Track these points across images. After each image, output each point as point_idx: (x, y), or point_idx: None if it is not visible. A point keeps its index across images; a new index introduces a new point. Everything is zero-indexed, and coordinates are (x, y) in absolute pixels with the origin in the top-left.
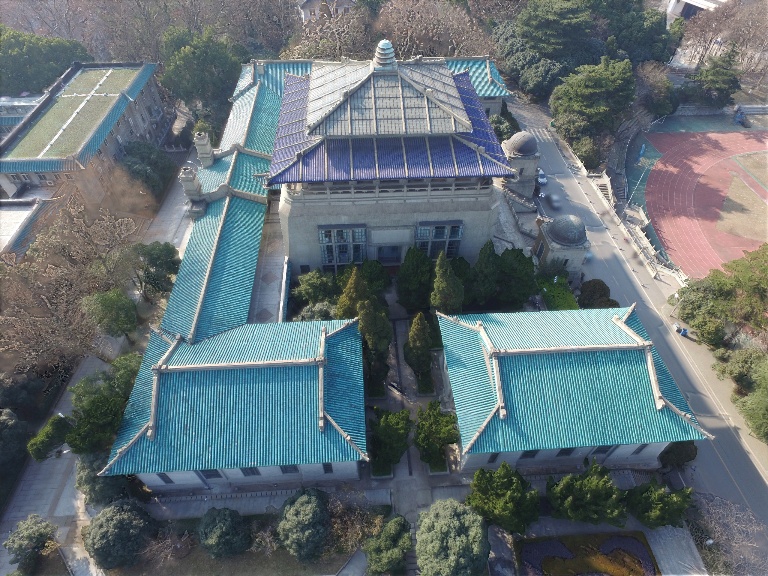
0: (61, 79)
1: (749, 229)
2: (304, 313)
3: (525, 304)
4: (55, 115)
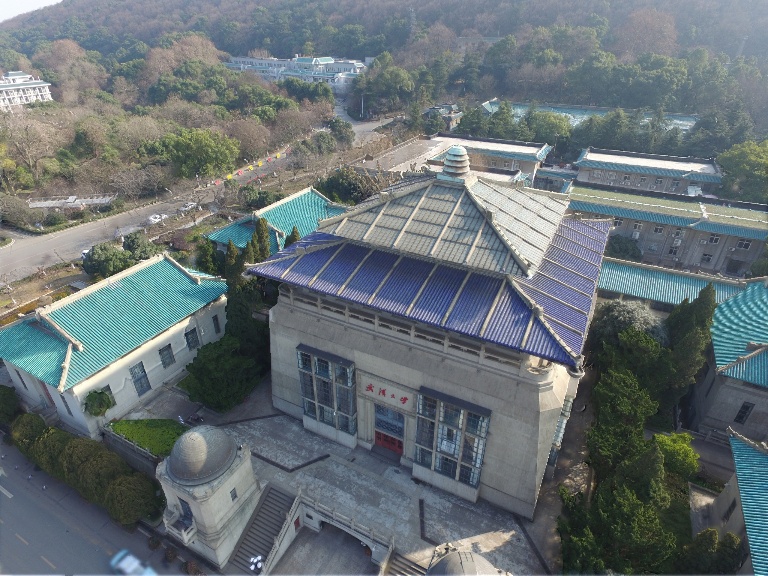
0: (736, 201)
1: None
2: None
3: (207, 414)
4: (656, 201)
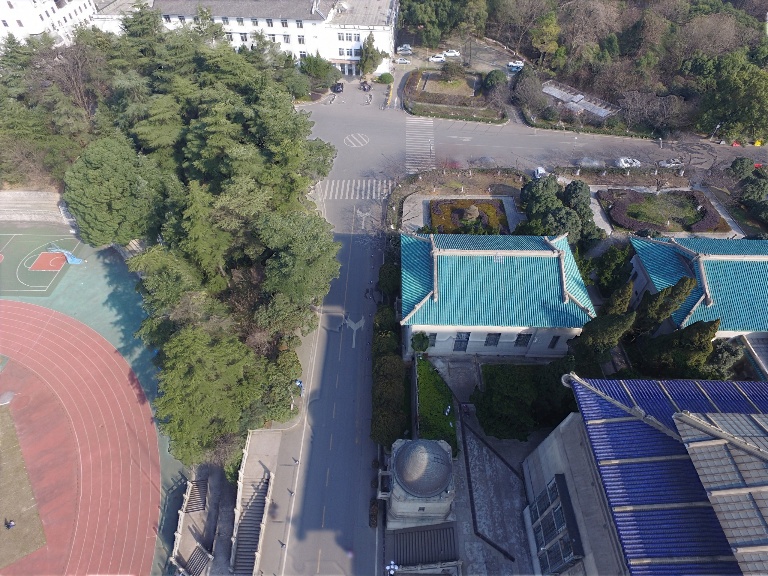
0: None
1: None
2: (740, 349)
3: None
4: None
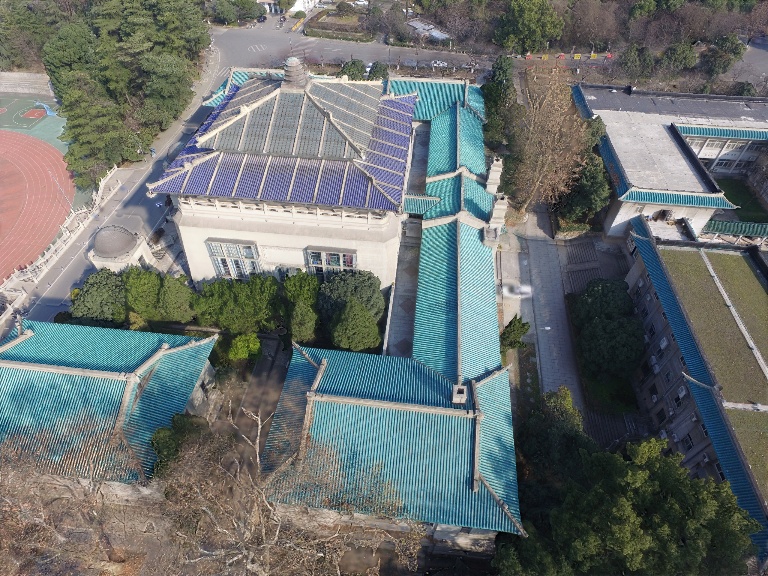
0: None
1: None
2: None
3: None
4: None
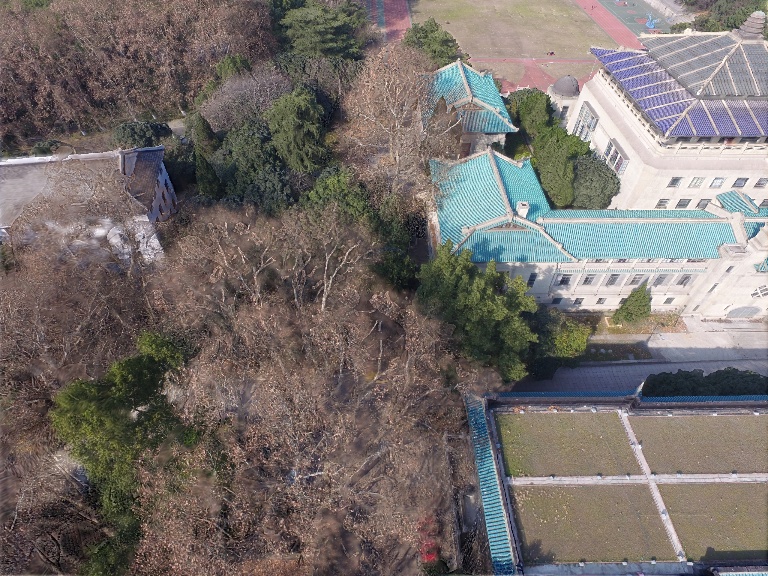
0: None
1: (513, 74)
2: None
3: None
4: (766, 522)
